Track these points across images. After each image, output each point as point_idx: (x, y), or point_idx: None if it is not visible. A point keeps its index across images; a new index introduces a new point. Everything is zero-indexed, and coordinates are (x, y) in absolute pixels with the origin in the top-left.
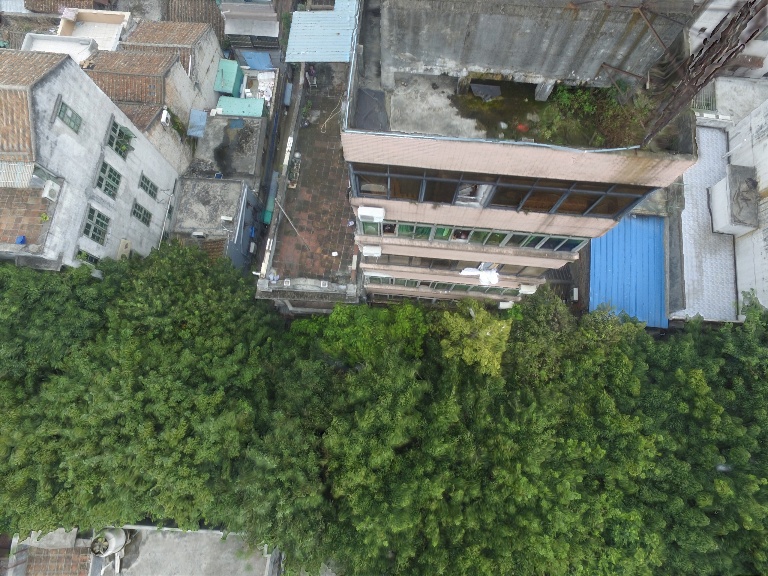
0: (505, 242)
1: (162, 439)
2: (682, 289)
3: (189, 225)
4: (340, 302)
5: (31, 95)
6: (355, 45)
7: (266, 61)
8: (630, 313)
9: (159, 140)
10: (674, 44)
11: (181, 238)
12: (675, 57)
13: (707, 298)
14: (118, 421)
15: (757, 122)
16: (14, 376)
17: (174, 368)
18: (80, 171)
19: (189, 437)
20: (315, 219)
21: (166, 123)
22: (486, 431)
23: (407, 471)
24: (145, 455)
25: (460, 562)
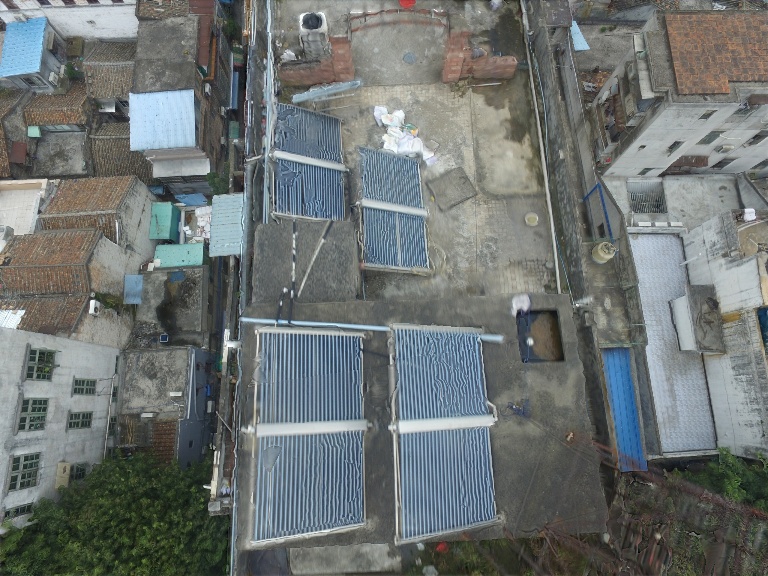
0: None
1: None
2: (656, 434)
3: (137, 404)
4: None
5: None
6: (235, 493)
7: (201, 199)
8: None
9: (90, 331)
10: (599, 424)
11: (130, 419)
12: (602, 444)
13: (683, 425)
14: None
15: (709, 237)
16: None
17: None
18: None
19: None
20: None
21: (95, 313)
22: None
23: None
24: None
25: None
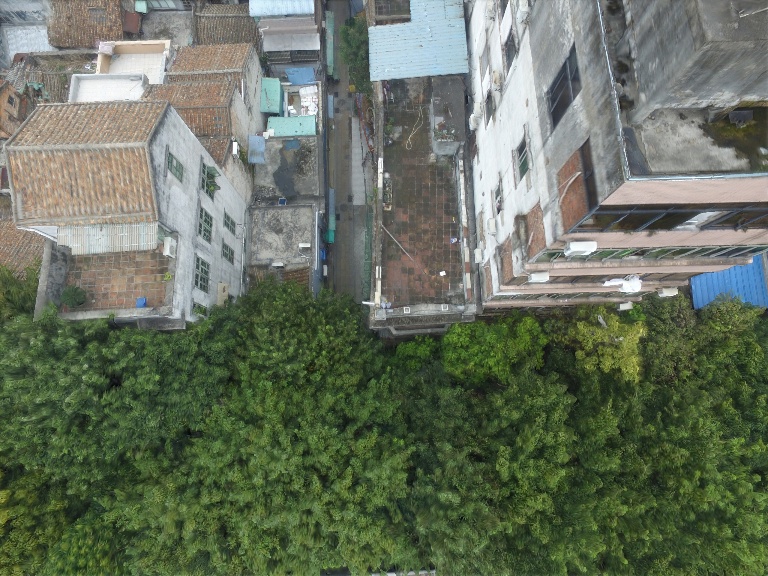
0: (684, 255)
1: (331, 492)
2: None
3: (265, 256)
4: (457, 322)
5: (149, 151)
6: (614, 84)
7: (309, 75)
8: (733, 297)
9: (231, 173)
10: None
11: (259, 270)
12: None
13: None
14: (282, 479)
15: None
16: (152, 443)
17: (317, 414)
18: (187, 221)
19: (359, 486)
20: (416, 240)
21: (237, 155)
22: (643, 439)
23: (575, 490)
24: (320, 511)
25: (652, 575)
